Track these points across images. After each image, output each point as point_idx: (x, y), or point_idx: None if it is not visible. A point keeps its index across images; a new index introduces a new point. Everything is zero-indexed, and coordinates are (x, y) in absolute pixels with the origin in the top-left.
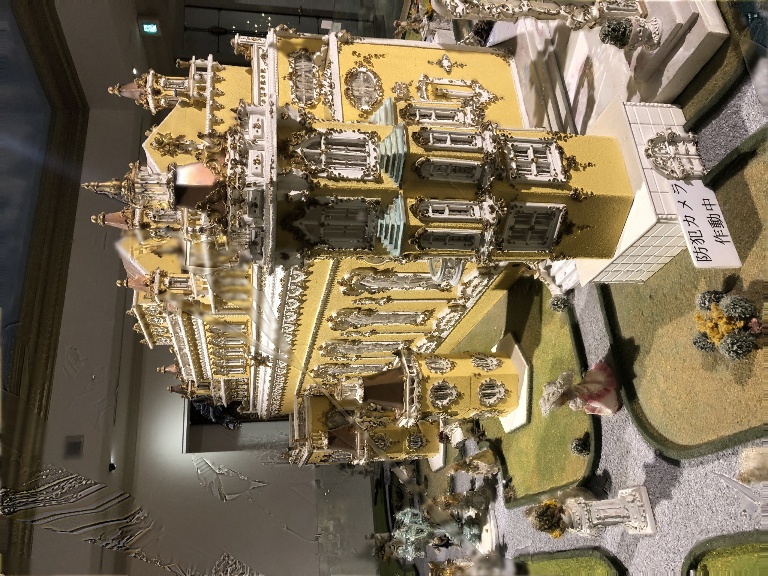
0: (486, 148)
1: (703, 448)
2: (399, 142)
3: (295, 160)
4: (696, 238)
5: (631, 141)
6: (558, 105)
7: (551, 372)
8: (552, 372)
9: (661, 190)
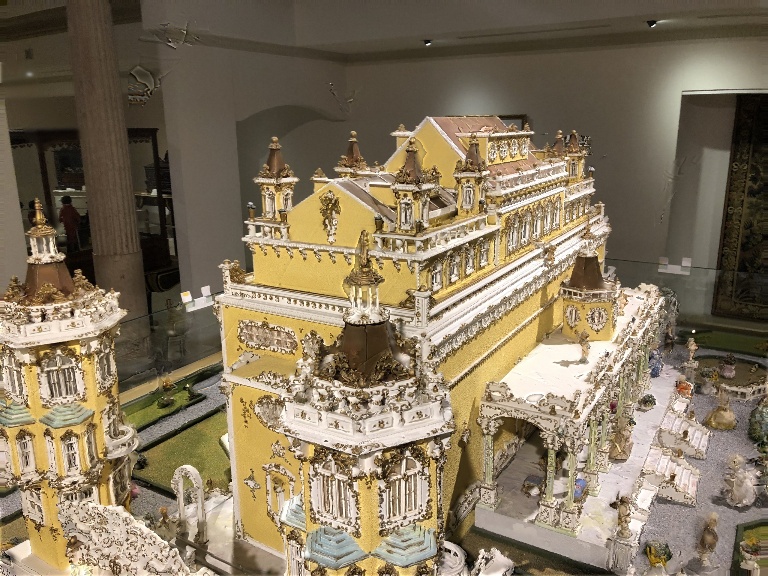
0: (7, 473)
1: (13, 513)
2: (4, 419)
3: (2, 348)
4: (1, 569)
5: (42, 574)
6: (221, 575)
7: (202, 468)
8: (201, 469)
9: (23, 570)
